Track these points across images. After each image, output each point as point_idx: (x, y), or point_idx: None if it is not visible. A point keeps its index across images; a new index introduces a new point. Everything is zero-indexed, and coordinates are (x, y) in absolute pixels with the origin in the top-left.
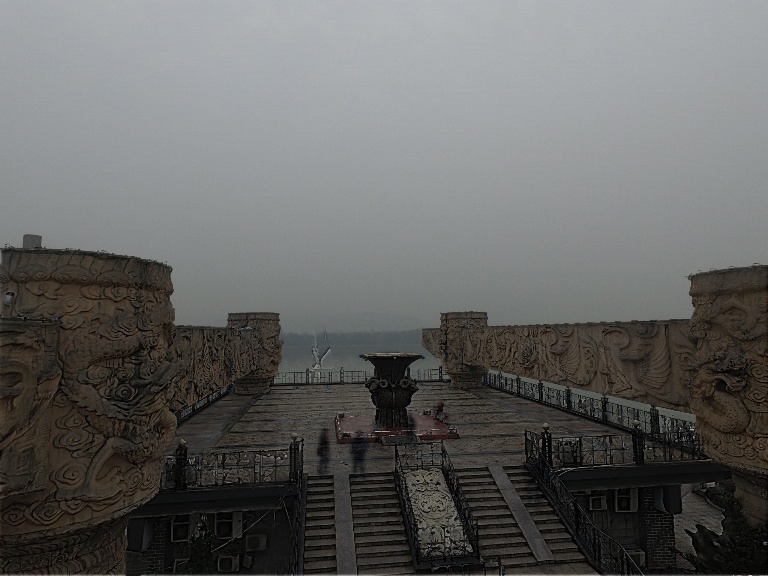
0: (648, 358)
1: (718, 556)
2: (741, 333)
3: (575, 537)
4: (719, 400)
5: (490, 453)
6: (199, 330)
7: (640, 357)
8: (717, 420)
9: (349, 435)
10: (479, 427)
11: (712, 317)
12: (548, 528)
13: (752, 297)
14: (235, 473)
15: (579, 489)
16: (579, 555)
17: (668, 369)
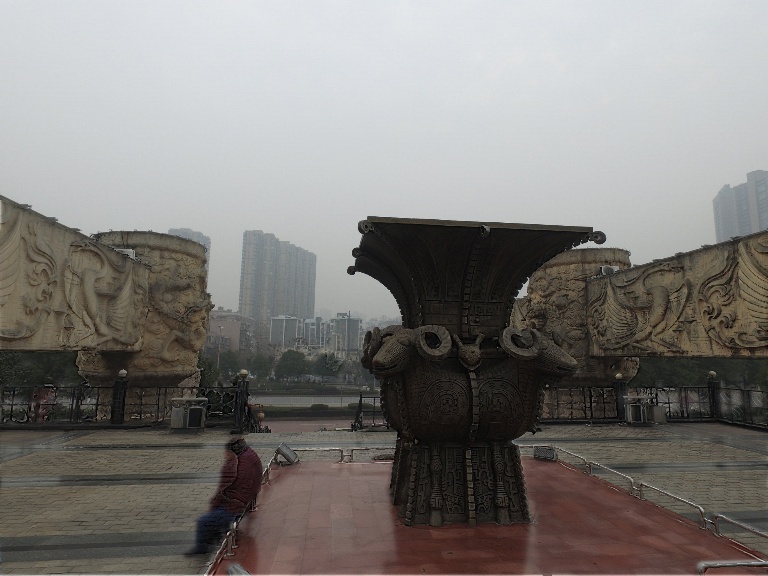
0: None
1: None
2: None
3: None
4: None
5: (266, 444)
6: (718, 248)
7: None
8: None
9: (537, 454)
10: (121, 515)
11: None
12: None
13: None
14: (617, 432)
15: None
16: None
17: None
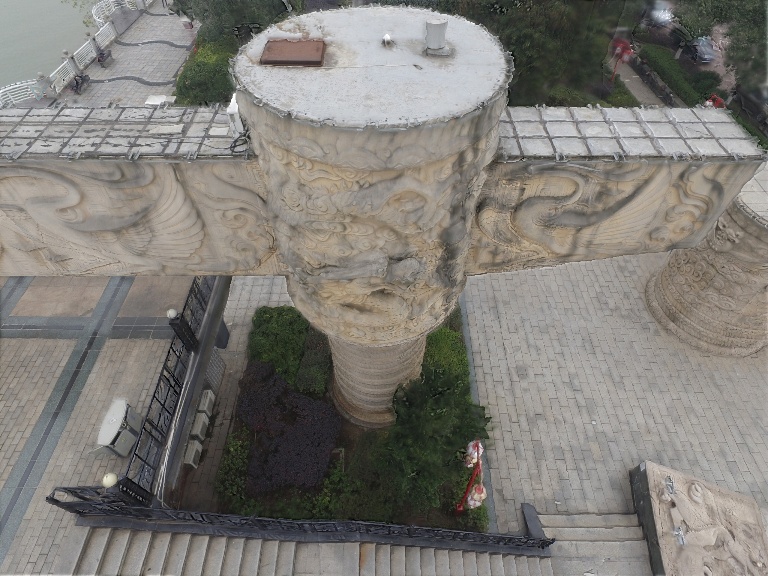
0: (147, 220)
1: (437, 457)
2: (416, 228)
3: (267, 537)
4: (375, 306)
5: None
6: None
7: (128, 222)
8: (367, 321)
9: None
10: None
11: (374, 215)
12: (237, 569)
13: (432, 170)
14: None
15: (180, 459)
16: (289, 547)
17: (201, 232)
